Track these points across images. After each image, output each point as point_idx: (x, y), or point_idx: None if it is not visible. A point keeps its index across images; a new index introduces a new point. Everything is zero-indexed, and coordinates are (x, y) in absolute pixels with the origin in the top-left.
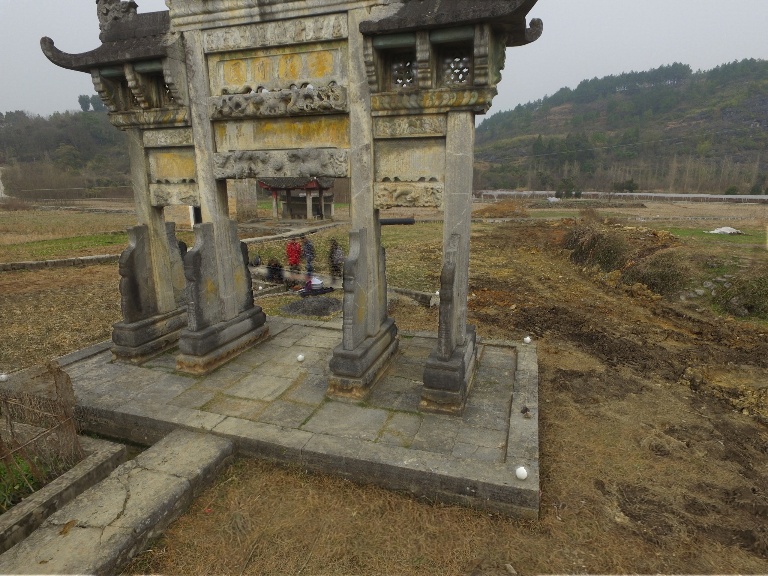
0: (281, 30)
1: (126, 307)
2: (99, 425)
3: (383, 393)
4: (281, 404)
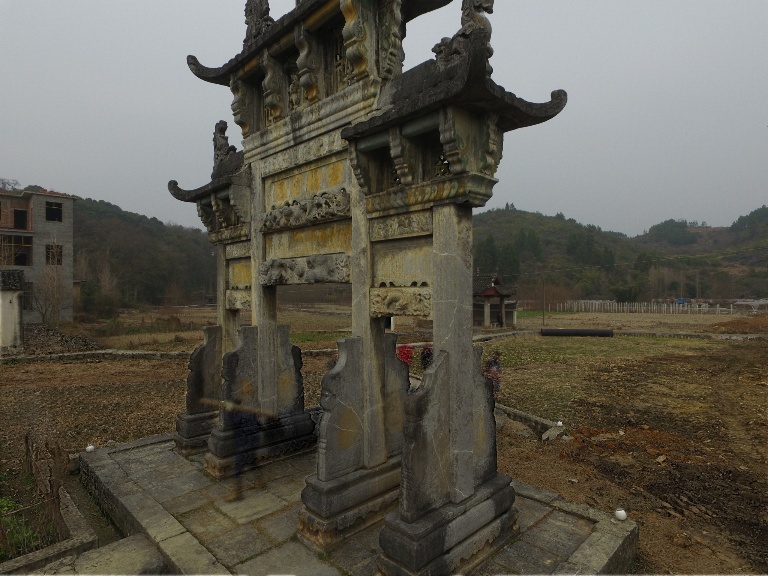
0: (307, 149)
1: (188, 399)
2: (112, 510)
3: (357, 547)
4: (246, 530)
